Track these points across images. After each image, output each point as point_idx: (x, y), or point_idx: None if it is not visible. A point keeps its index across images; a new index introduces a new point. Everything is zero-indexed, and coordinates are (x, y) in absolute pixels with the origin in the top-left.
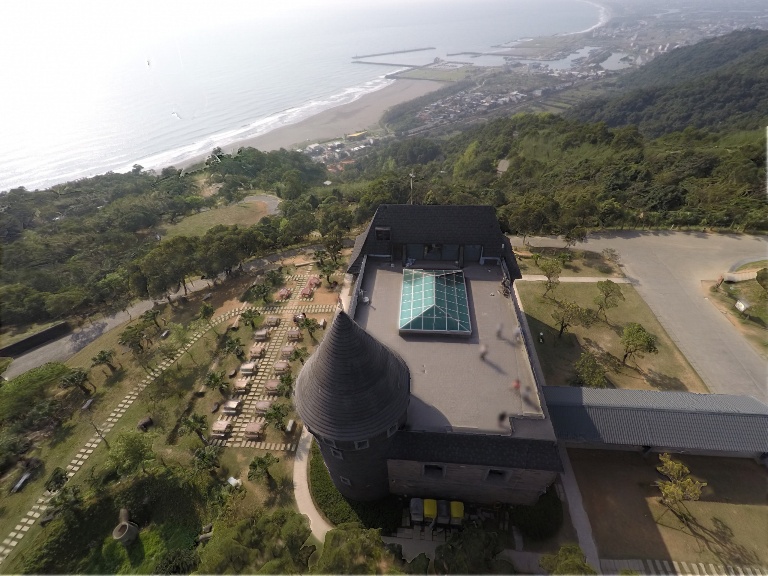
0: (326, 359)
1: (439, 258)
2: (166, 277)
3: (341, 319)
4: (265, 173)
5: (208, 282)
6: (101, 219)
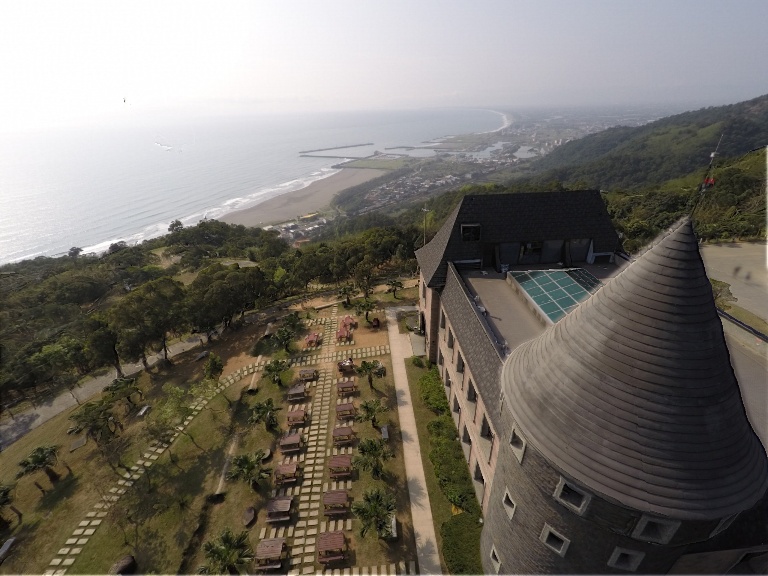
0: (651, 333)
1: (537, 261)
2: (147, 329)
3: (690, 237)
4: (232, 241)
5: (201, 337)
6: (31, 294)
